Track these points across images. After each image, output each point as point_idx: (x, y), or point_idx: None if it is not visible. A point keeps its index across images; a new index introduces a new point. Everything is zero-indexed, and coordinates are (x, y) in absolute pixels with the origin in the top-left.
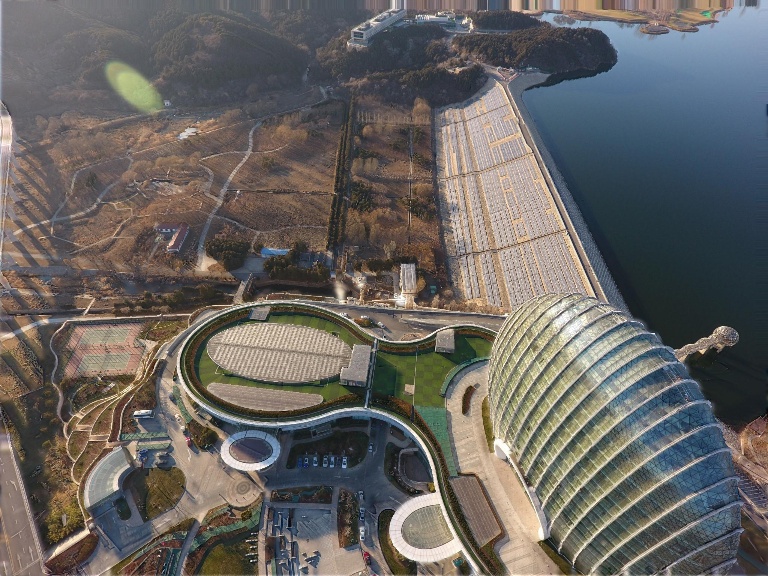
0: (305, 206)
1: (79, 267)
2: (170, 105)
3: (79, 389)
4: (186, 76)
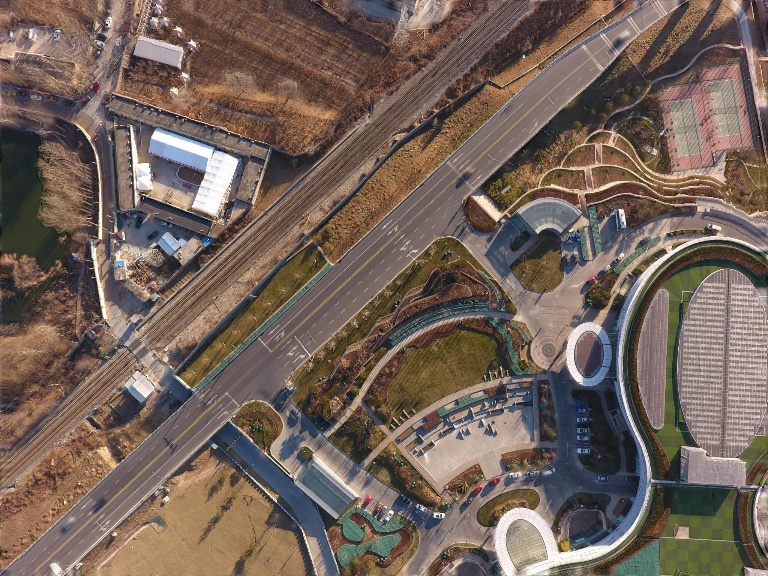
0: None
1: None
2: None
3: (646, 118)
4: None
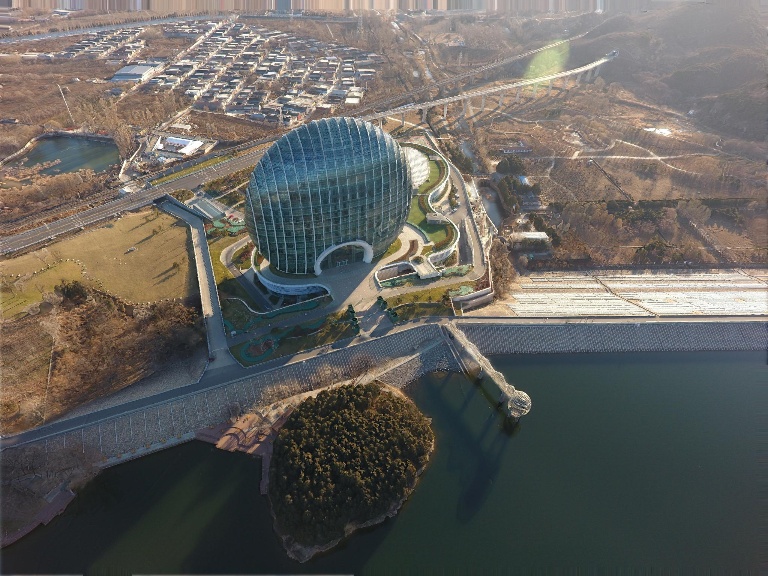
0: (601, 192)
1: (470, 128)
2: (691, 114)
3: None
4: (732, 100)
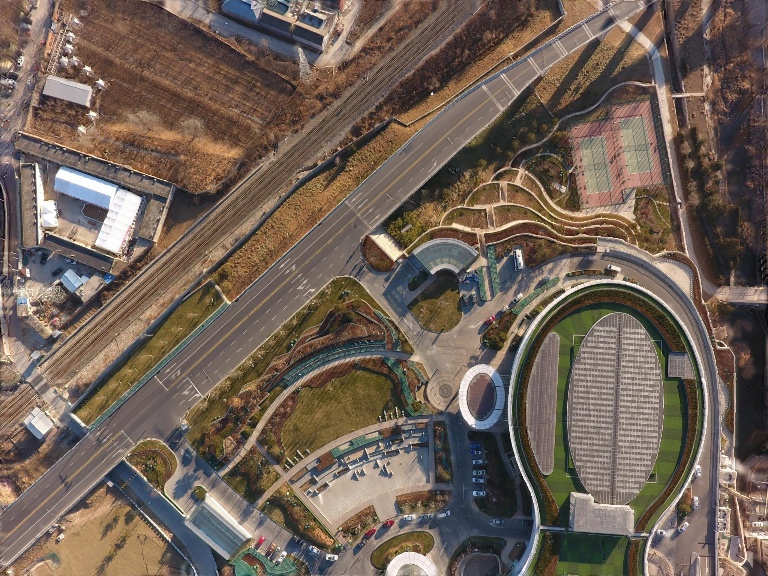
0: None
1: (765, 41)
2: None
3: (555, 155)
4: None
